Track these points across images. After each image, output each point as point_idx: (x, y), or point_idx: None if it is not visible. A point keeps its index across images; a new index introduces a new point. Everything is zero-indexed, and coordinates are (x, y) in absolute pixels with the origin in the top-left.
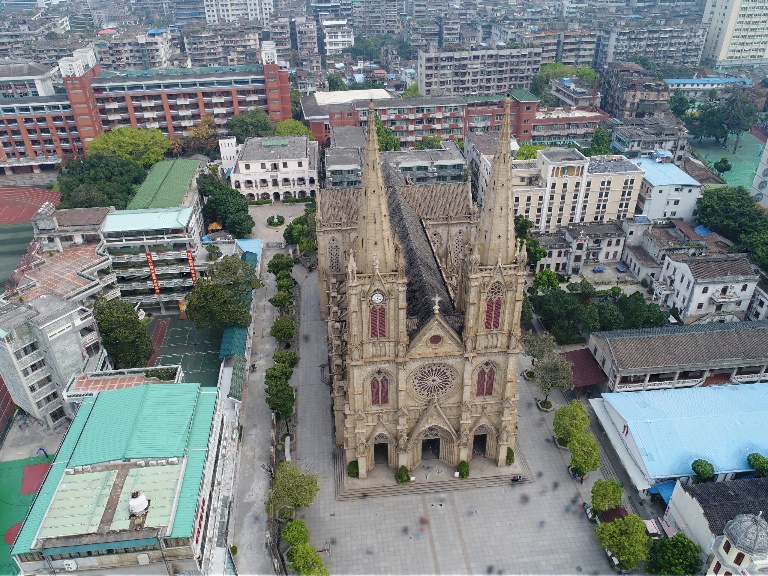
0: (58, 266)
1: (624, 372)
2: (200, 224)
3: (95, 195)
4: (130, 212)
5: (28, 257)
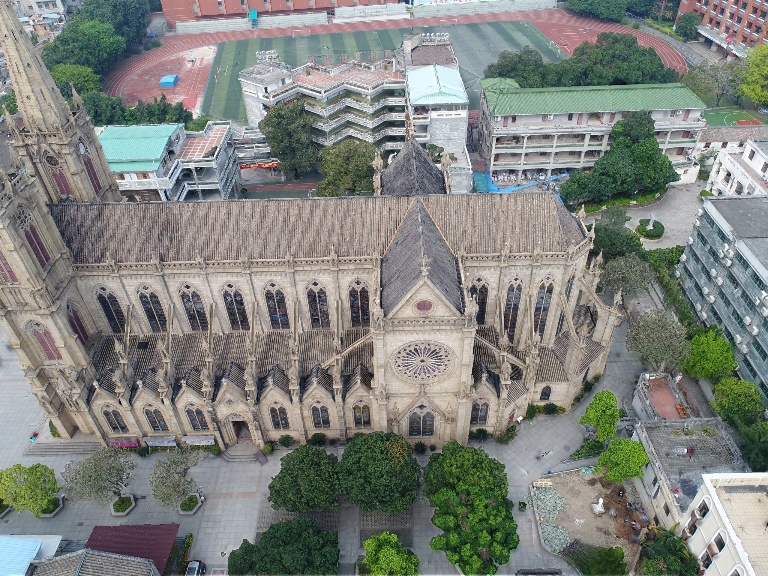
0: (365, 75)
1: (29, 571)
2: (587, 162)
3: (508, 57)
4: (445, 73)
5: (368, 58)
